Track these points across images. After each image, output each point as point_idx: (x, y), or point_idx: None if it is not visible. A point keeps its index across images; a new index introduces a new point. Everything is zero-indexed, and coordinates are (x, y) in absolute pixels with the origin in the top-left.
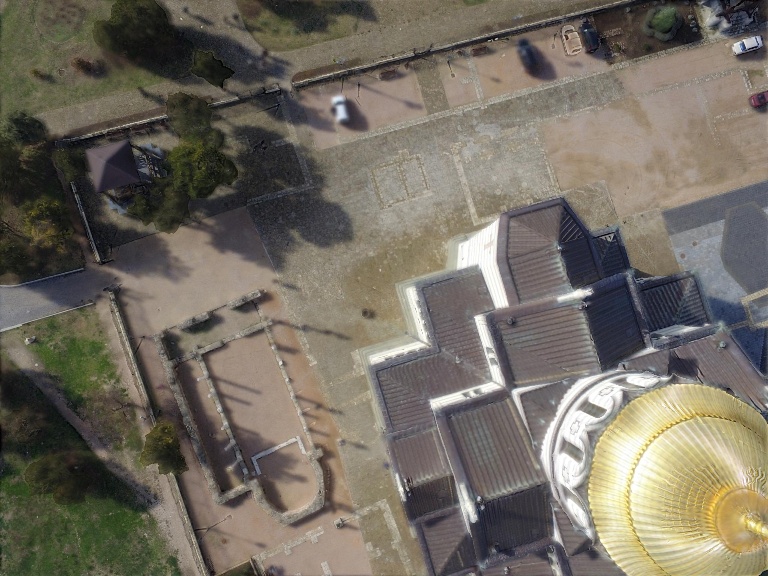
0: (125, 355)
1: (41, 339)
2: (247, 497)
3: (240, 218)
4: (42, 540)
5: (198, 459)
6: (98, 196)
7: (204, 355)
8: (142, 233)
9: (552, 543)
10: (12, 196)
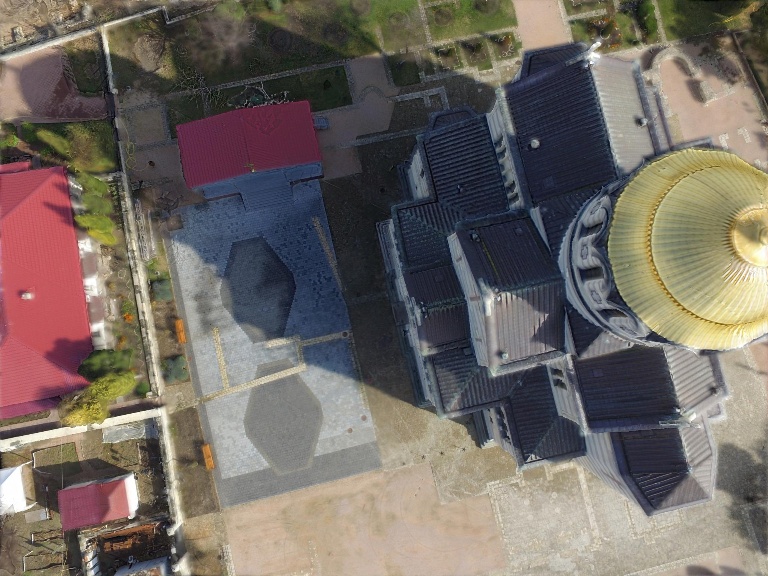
0: None
1: None
2: None
3: None
4: None
5: None
6: None
7: None
8: None
9: None
10: None
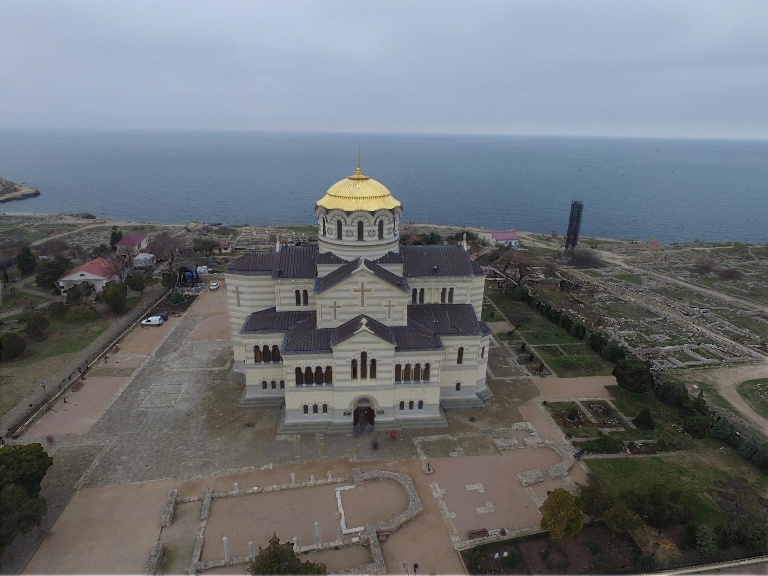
0: None
1: None
2: (385, 543)
3: (84, 498)
4: None
5: None
6: None
7: None
8: None
9: None
10: None
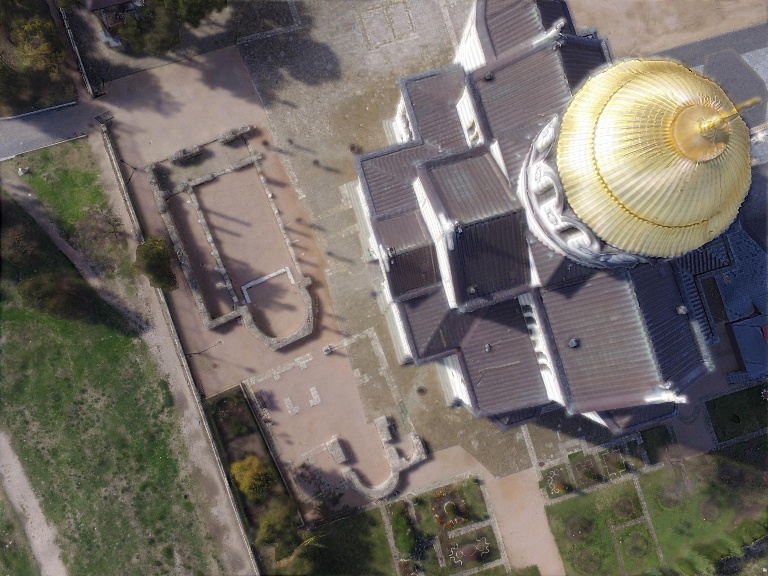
0: (117, 181)
1: (34, 170)
2: (237, 324)
3: (230, 56)
4: (35, 364)
5: (189, 287)
6: (90, 32)
7: (195, 188)
8: (134, 69)
9: (529, 290)
10: (6, 26)
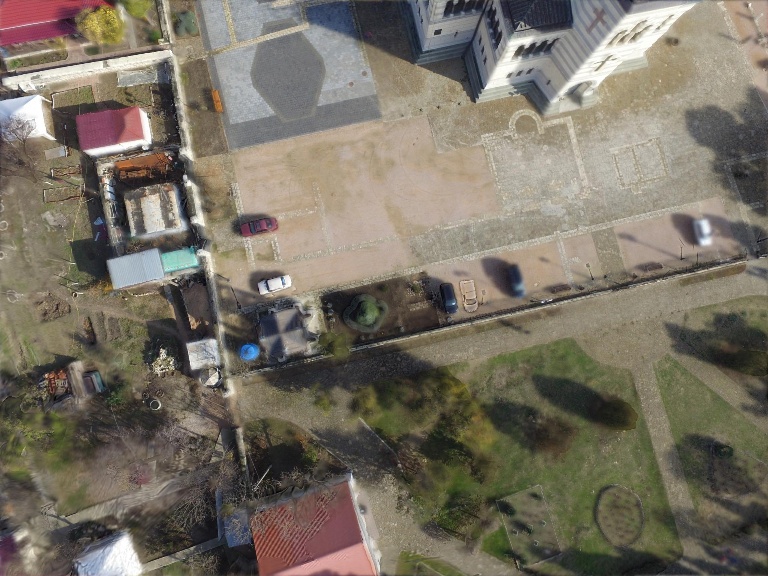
0: None
1: None
2: None
3: None
4: None
5: None
6: None
7: None
8: None
9: None
10: None
